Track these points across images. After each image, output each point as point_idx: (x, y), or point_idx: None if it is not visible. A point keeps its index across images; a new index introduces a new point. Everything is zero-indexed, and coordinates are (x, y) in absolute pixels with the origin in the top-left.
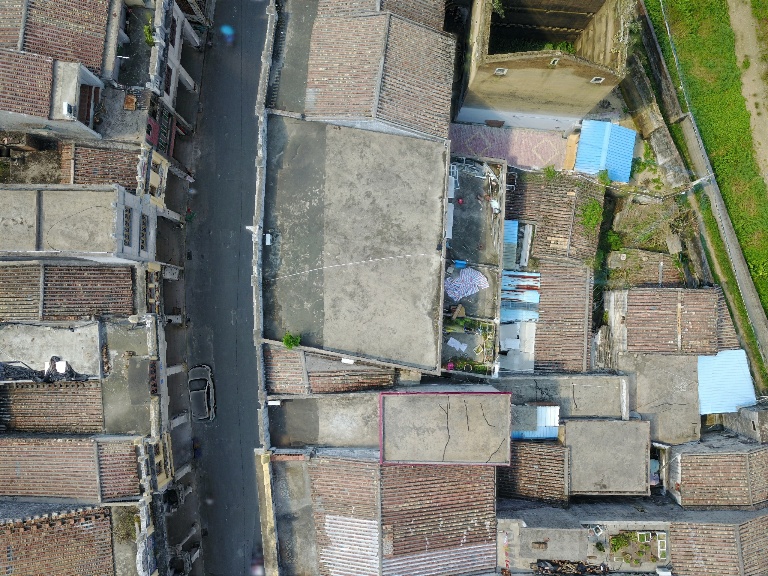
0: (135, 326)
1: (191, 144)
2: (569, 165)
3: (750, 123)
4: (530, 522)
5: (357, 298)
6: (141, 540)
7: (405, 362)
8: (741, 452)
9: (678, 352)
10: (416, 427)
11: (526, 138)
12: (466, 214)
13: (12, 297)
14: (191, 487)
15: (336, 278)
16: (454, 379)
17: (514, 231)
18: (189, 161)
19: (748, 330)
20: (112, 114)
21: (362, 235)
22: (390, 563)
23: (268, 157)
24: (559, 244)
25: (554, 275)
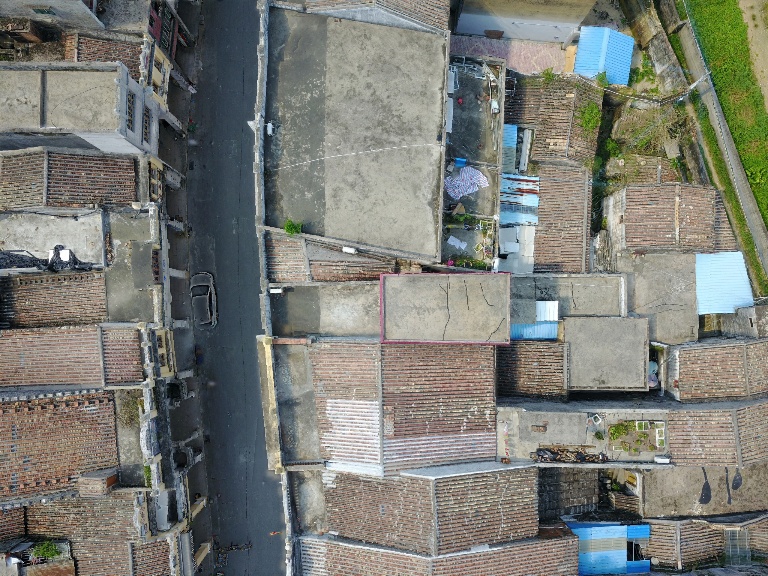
0: (138, 214)
1: (193, 56)
2: None
3: (747, 35)
4: (529, 409)
5: (358, 188)
6: (144, 419)
7: (405, 251)
8: (738, 343)
9: (676, 245)
10: (416, 307)
11: (525, 50)
12: (466, 114)
13: (16, 186)
14: (193, 392)
15: (337, 168)
16: None
17: (513, 135)
18: (191, 72)
19: (746, 238)
20: (115, 4)
21: (363, 126)
22: (391, 443)
23: (269, 49)
24: (558, 145)
25: (553, 179)
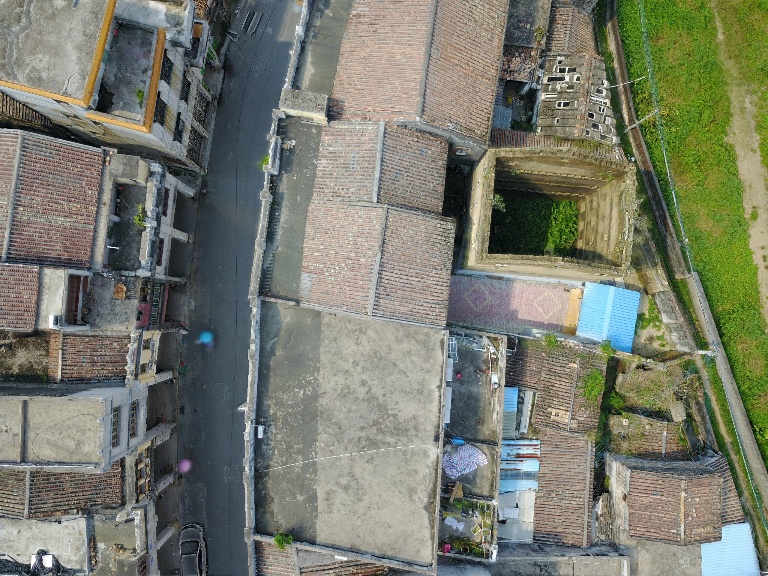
0: (123, 521)
1: (184, 295)
2: (571, 320)
3: (757, 277)
4: None
5: (351, 491)
6: None
7: (400, 557)
8: None
9: (681, 542)
10: None
11: (527, 291)
12: (465, 388)
13: None
14: None
15: (330, 470)
16: (451, 560)
17: (514, 398)
18: (182, 312)
19: (753, 493)
20: (101, 303)
21: (357, 425)
22: None
23: (261, 343)
24: (560, 417)
25: (554, 443)
